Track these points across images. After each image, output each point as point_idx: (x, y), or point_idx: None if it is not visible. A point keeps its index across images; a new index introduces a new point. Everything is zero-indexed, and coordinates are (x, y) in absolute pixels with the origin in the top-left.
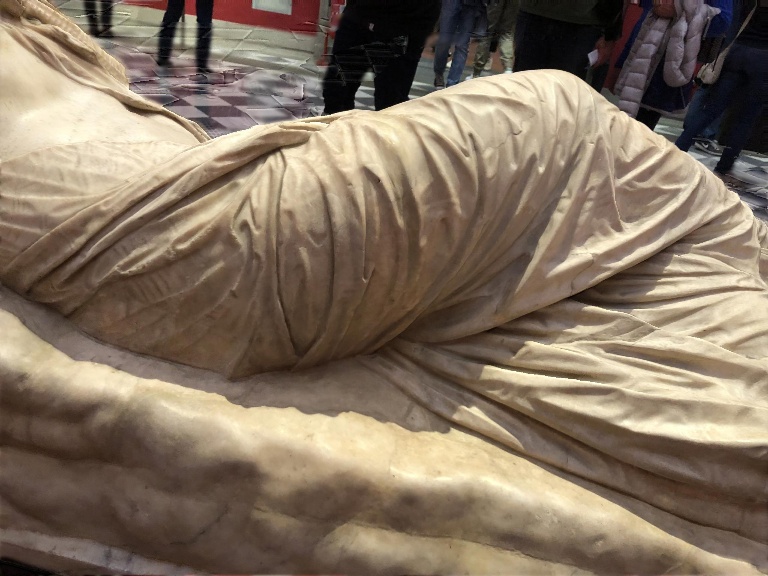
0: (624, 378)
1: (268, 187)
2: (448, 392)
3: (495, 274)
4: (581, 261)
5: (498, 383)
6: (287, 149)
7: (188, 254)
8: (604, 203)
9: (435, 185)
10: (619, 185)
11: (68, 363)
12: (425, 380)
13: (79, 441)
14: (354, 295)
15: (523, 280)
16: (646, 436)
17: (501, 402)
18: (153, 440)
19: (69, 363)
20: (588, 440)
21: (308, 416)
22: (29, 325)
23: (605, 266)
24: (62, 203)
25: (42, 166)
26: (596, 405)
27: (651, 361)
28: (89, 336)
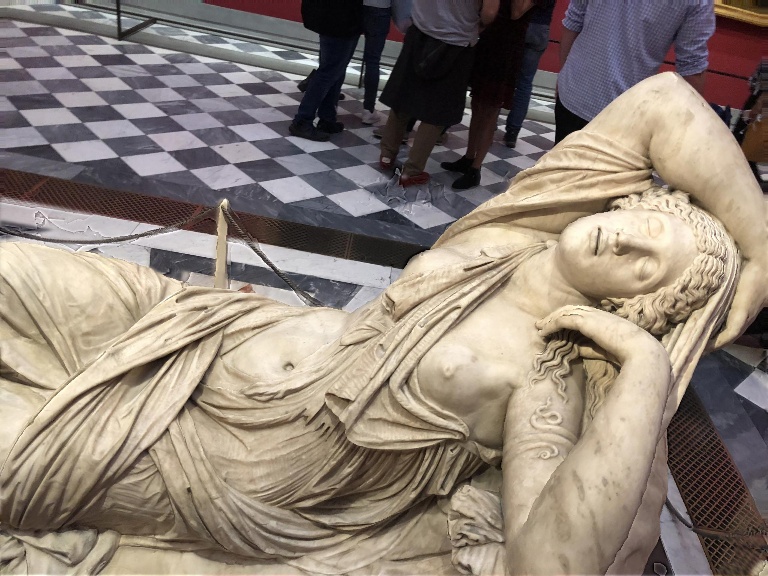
0: None
1: None
2: None
3: None
4: None
5: None
6: None
7: None
8: None
9: None
10: None
11: None
12: None
13: None
14: None
15: None
16: None
17: None
18: None
19: None
20: None
21: None
22: None
23: None
24: None
25: None
26: None
27: None
28: None
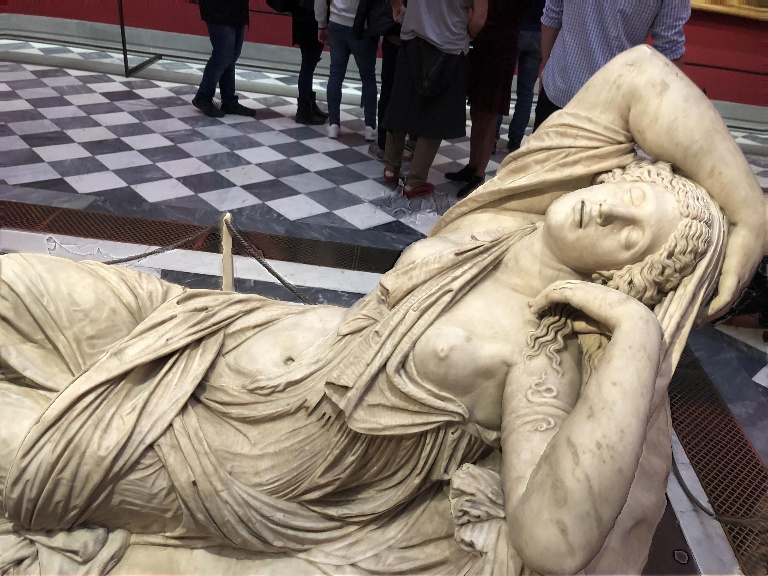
0: None
1: None
2: None
3: None
4: None
5: None
6: None
7: None
8: None
9: None
10: None
11: None
12: None
13: None
14: None
15: None
16: None
17: None
18: None
19: None
20: None
21: None
22: None
23: None
24: None
25: None
26: None
27: None
28: None
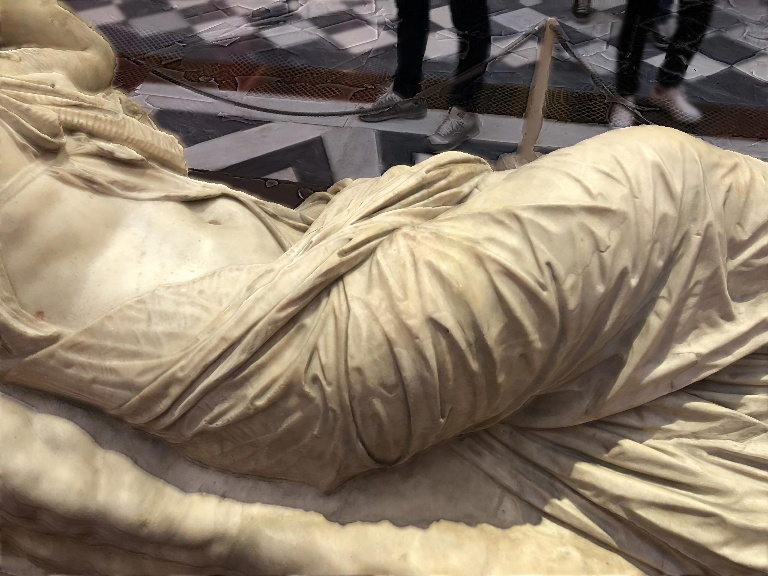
0: (727, 493)
1: (334, 337)
2: (539, 479)
3: (585, 372)
4: (682, 363)
5: (589, 485)
6: (350, 275)
7: (267, 407)
8: (712, 294)
9: (510, 325)
10: (733, 268)
11: (180, 498)
12: (515, 464)
13: (203, 559)
14: (433, 430)
15: (615, 388)
16: (747, 568)
17: (593, 501)
18: (264, 564)
19: (181, 497)
20: (684, 554)
21: (401, 529)
22: (141, 464)
23: (711, 364)
24: (143, 368)
25: (118, 330)
26: (694, 526)
27: (760, 469)
28: (194, 461)
